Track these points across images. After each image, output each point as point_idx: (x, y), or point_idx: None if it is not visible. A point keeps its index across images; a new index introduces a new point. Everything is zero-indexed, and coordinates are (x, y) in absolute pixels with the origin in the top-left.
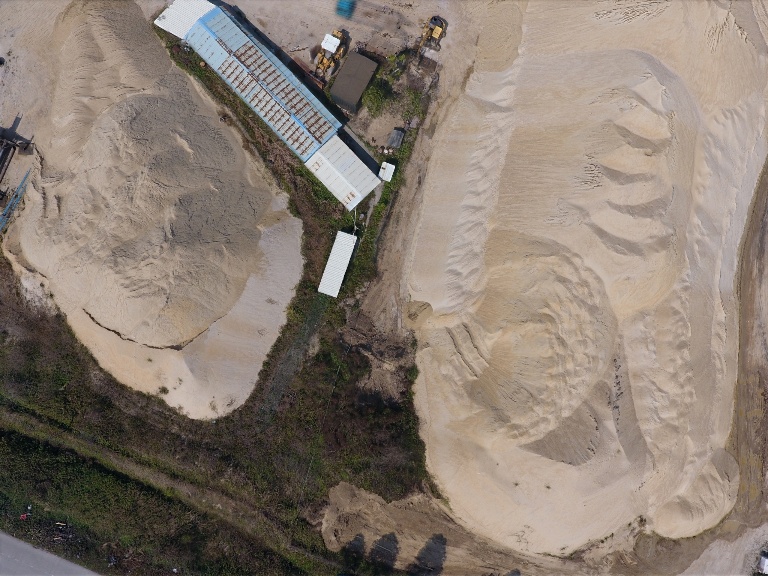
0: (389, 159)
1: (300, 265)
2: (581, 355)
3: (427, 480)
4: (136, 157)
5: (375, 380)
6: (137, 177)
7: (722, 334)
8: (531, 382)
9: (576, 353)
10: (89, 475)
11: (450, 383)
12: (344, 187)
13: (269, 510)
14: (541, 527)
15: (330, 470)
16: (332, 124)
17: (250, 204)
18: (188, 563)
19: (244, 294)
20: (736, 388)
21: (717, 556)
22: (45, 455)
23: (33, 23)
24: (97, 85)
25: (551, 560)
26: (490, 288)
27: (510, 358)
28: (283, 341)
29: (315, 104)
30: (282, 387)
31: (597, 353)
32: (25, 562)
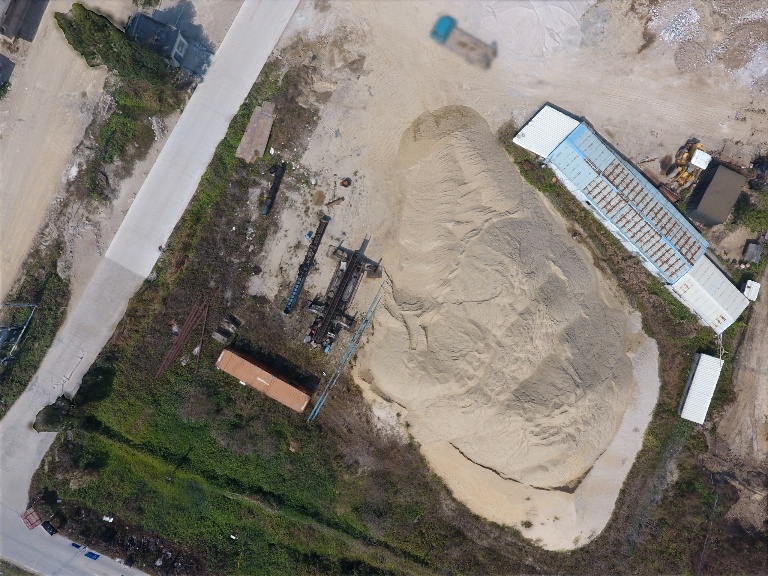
0: (746, 274)
1: (657, 388)
2: None
3: None
4: (529, 293)
5: (735, 508)
6: (533, 315)
7: None
8: None
9: None
10: None
11: None
12: (714, 310)
13: None
14: None
15: None
16: (701, 243)
17: (614, 328)
18: None
19: (620, 427)
20: None
21: None
22: None
23: (379, 141)
24: (460, 209)
25: None
26: None
27: None
28: (637, 467)
29: (683, 223)
30: (638, 516)
31: None
32: None
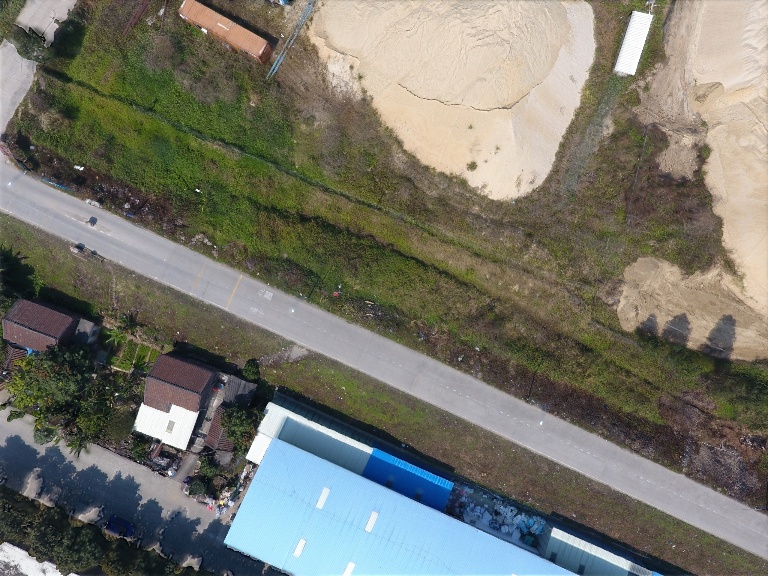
0: None
1: (593, 48)
2: None
3: (723, 255)
4: None
5: (667, 160)
6: None
7: None
8: None
9: None
10: (392, 257)
11: (753, 152)
12: None
13: (569, 287)
14: None
15: (629, 247)
16: None
17: None
18: (496, 337)
19: (556, 64)
20: None
21: None
22: (350, 238)
23: None
24: None
25: None
26: None
27: None
28: (576, 124)
29: None
30: (577, 168)
31: None
32: (340, 337)
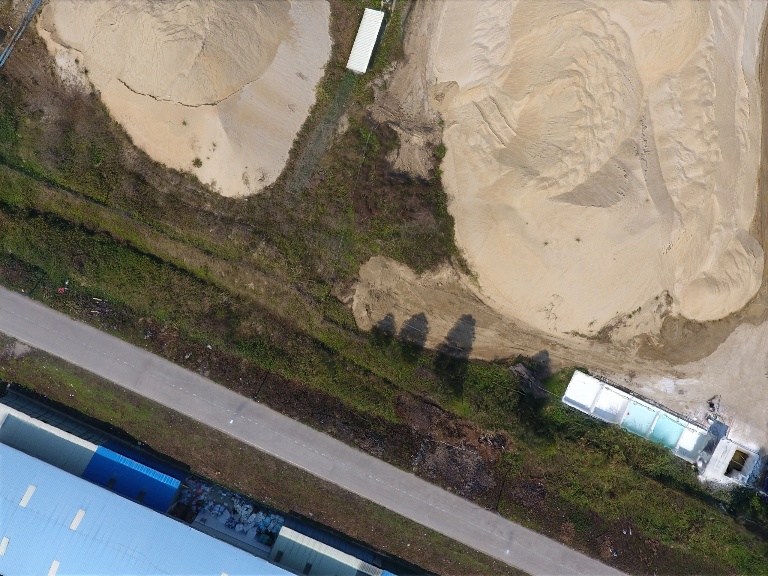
0: None
1: (328, 45)
2: (608, 108)
3: (456, 255)
4: None
5: (403, 159)
6: None
7: (745, 109)
8: (559, 138)
9: (603, 106)
10: (124, 253)
11: (478, 152)
12: None
13: (301, 286)
14: (570, 294)
15: (361, 245)
16: None
17: None
18: (223, 335)
19: (275, 61)
20: (759, 173)
21: (743, 340)
22: (81, 234)
23: None
24: None
25: (579, 341)
26: (516, 61)
27: (537, 122)
28: (312, 121)
29: None
30: (312, 166)
31: (624, 109)
32: (63, 333)
